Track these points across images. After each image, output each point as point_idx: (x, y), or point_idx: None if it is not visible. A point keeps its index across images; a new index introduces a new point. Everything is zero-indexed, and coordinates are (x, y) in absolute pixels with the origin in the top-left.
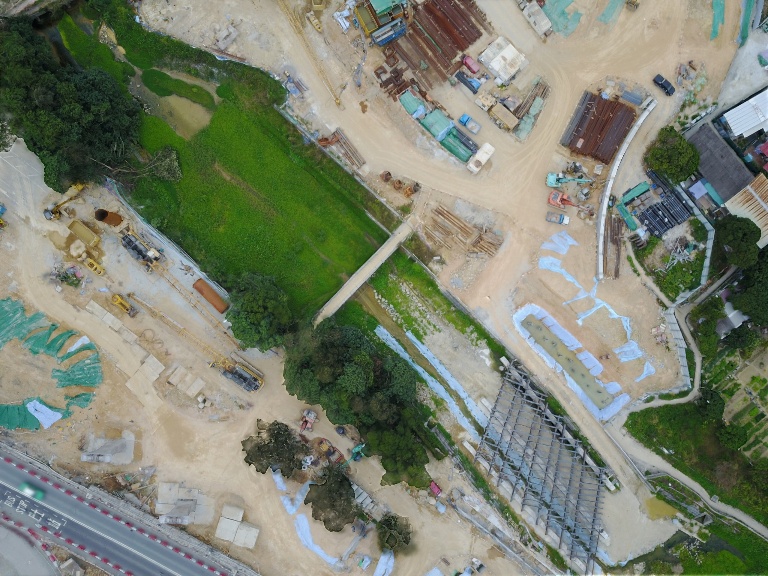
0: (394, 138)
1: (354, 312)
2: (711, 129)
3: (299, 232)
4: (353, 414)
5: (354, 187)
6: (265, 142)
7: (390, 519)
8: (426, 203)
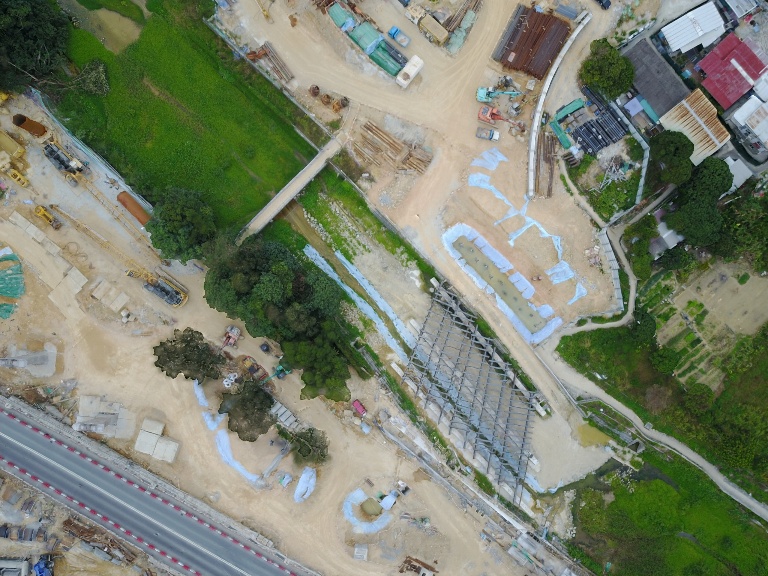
0: (323, 52)
1: (282, 230)
2: (648, 44)
3: (227, 148)
4: (272, 326)
5: (283, 102)
6: (194, 57)
7: (307, 432)
8: (355, 119)
